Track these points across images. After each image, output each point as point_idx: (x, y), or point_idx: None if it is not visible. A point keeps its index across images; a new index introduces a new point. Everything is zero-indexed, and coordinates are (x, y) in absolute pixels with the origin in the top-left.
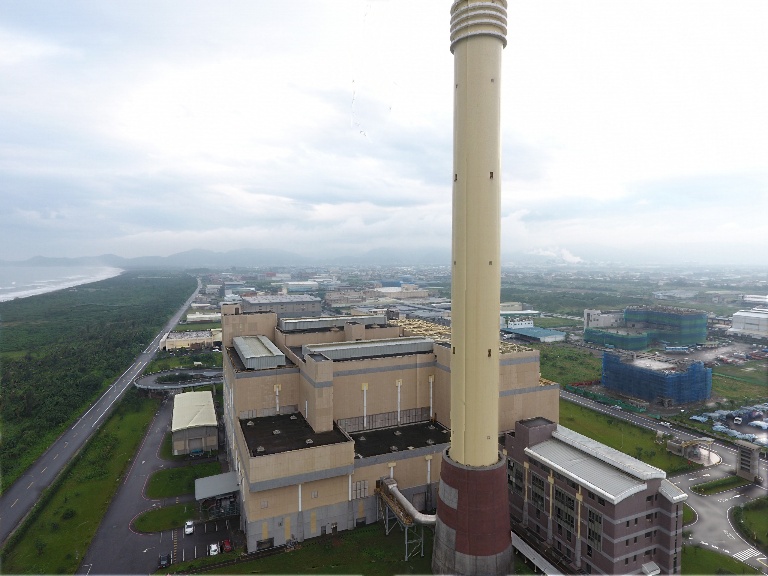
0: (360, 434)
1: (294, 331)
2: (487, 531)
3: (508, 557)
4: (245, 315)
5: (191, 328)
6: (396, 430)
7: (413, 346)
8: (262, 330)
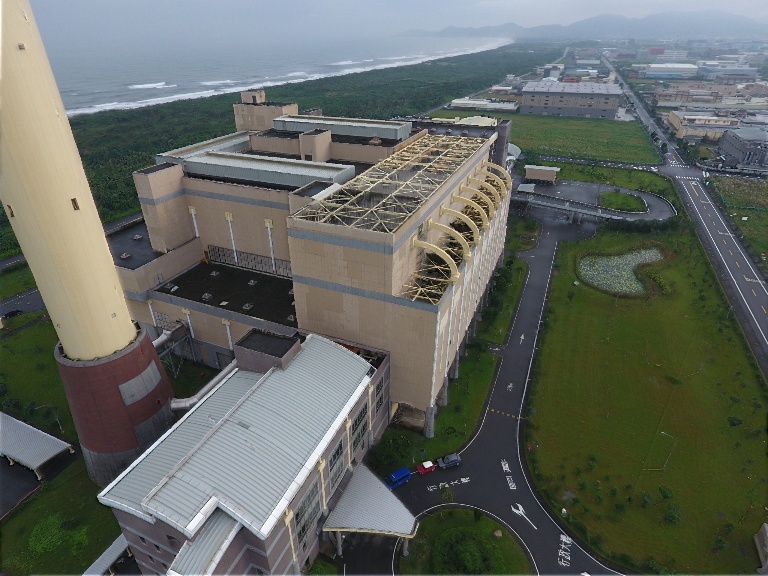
0: (230, 268)
1: (285, 132)
2: (76, 423)
3: (111, 462)
4: (252, 106)
5: (445, 114)
6: (263, 279)
7: (300, 178)
8: (270, 126)
